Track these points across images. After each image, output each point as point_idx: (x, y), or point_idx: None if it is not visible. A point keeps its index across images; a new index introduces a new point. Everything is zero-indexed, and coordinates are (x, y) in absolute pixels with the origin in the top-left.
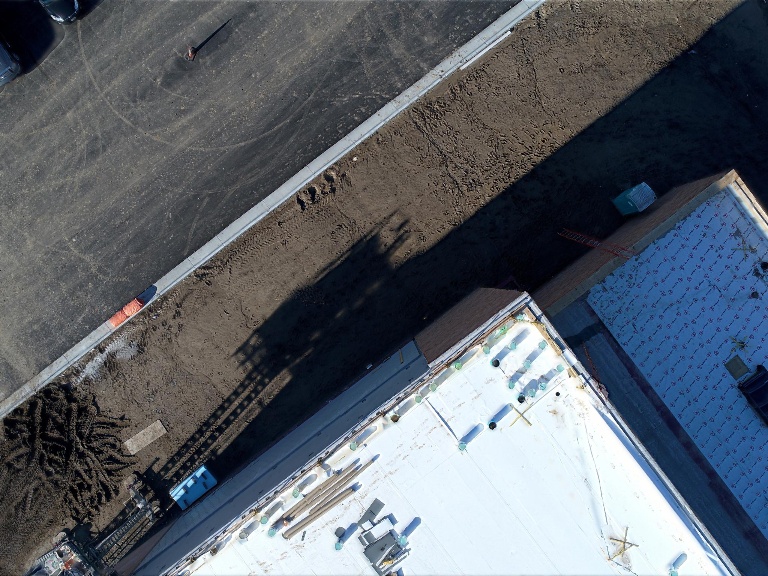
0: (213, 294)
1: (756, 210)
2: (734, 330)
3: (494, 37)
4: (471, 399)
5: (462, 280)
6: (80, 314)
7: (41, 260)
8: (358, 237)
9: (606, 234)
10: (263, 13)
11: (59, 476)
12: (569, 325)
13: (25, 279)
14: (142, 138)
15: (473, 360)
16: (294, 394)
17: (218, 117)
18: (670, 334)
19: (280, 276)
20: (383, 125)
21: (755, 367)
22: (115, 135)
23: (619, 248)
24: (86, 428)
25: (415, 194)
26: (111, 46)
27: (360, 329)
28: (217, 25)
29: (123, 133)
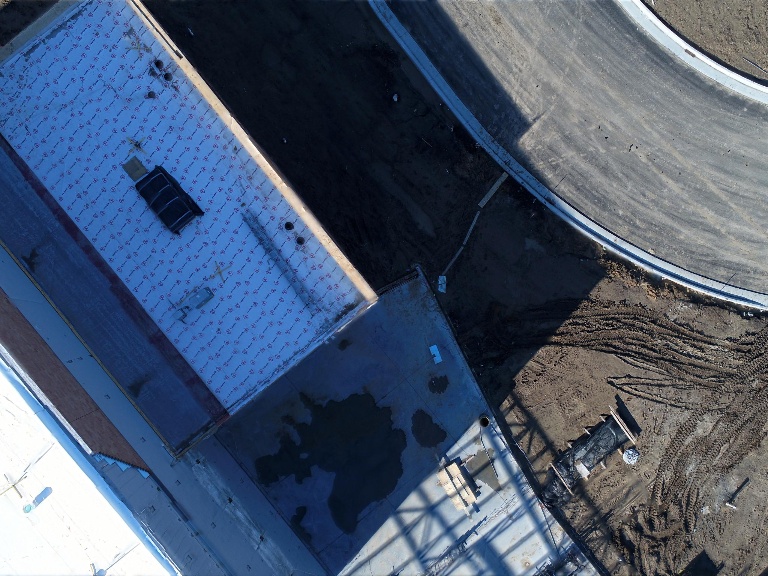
0: None
1: (134, 3)
2: (131, 131)
3: None
4: None
5: None
6: None
7: None
8: None
9: None
10: None
11: None
12: None
13: None
14: None
15: None
16: None
17: None
18: (64, 136)
19: None
20: None
21: (153, 168)
22: None
23: None
24: None
25: None
26: None
27: None
28: None
29: None
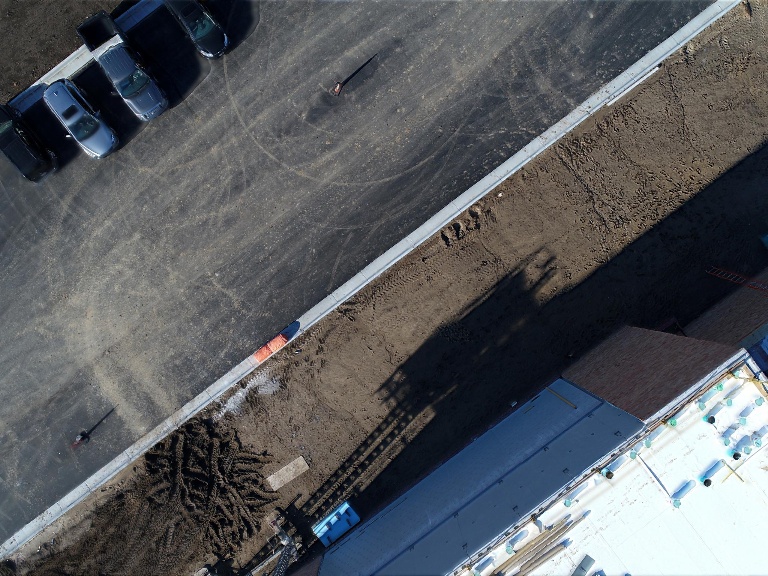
0: (356, 330)
1: None
2: None
3: (642, 73)
4: (683, 455)
5: (608, 318)
6: (222, 349)
7: (184, 295)
8: (503, 274)
9: (755, 272)
10: (409, 48)
11: (200, 511)
12: None
13: (167, 314)
14: (286, 173)
15: (686, 416)
16: (437, 431)
17: (363, 152)
18: None
19: (425, 312)
20: (529, 161)
21: None
22: (259, 170)
23: None
24: (228, 463)
25: (561, 231)
26: (257, 81)
27: (505, 366)
28: (363, 60)
29: (267, 168)
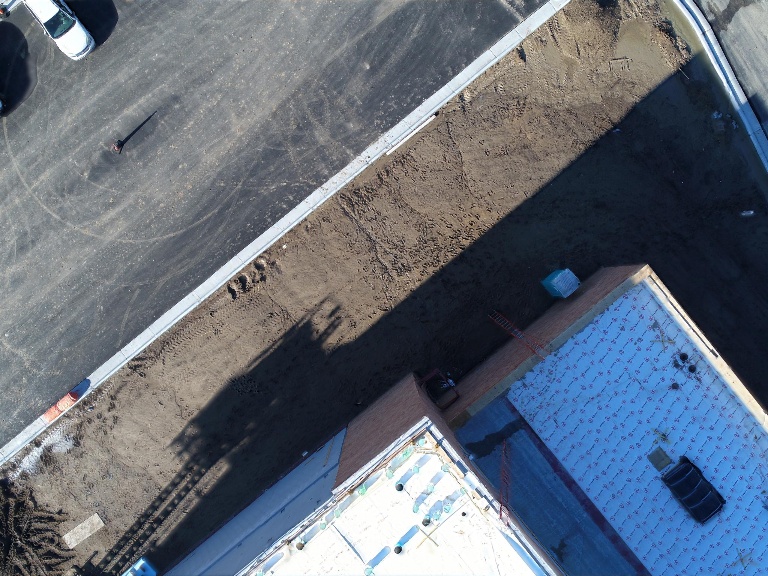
0: (147, 385)
1: (671, 304)
2: (655, 422)
3: (419, 122)
4: (377, 522)
5: (395, 365)
6: (15, 409)
7: None
8: (290, 325)
9: (536, 315)
10: (188, 104)
11: None
12: (490, 422)
13: None
14: (71, 232)
15: (378, 483)
16: (231, 483)
17: (147, 209)
18: (592, 428)
19: (213, 366)
20: (311, 212)
21: (677, 458)
22: (44, 230)
23: (537, 345)
24: (24, 523)
25: (345, 280)
26: (37, 142)
27: (294, 416)
28: (143, 118)
29: (52, 228)
